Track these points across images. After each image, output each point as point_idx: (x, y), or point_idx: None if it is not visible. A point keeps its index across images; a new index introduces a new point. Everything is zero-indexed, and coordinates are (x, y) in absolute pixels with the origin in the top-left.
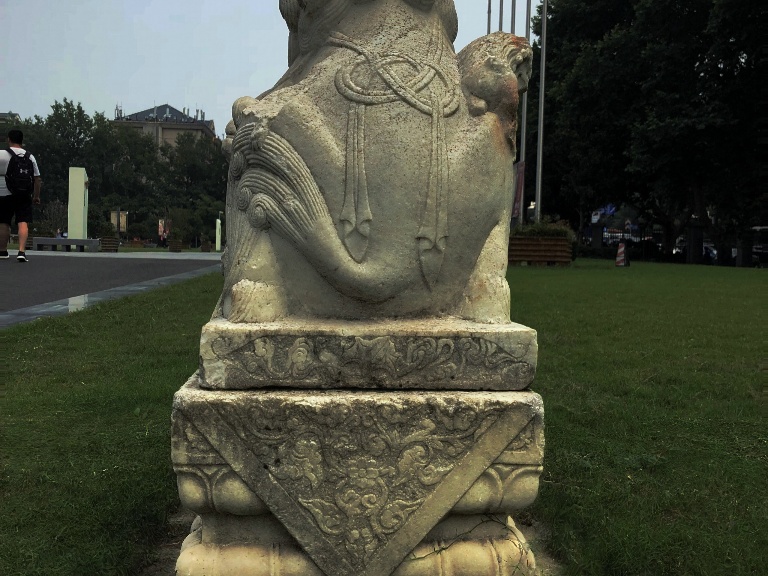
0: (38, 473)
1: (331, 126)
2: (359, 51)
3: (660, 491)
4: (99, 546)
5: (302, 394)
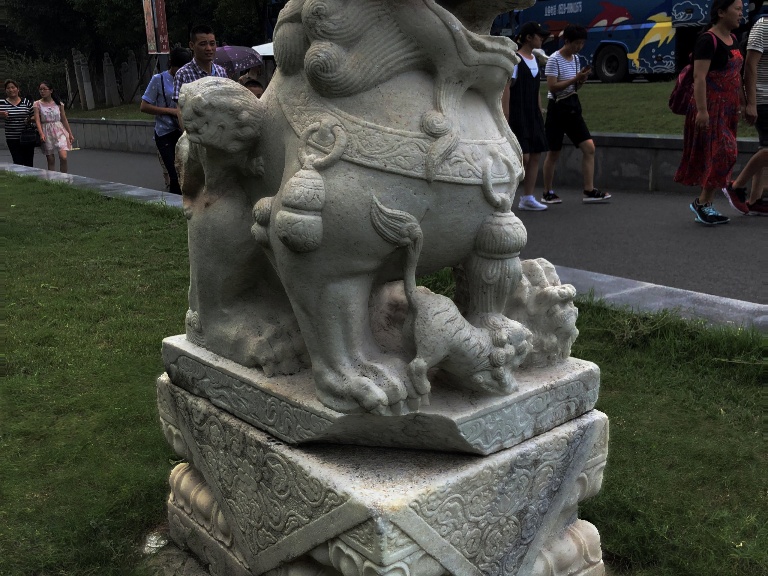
0: (759, 511)
1: None
2: None
3: None
4: None
5: None
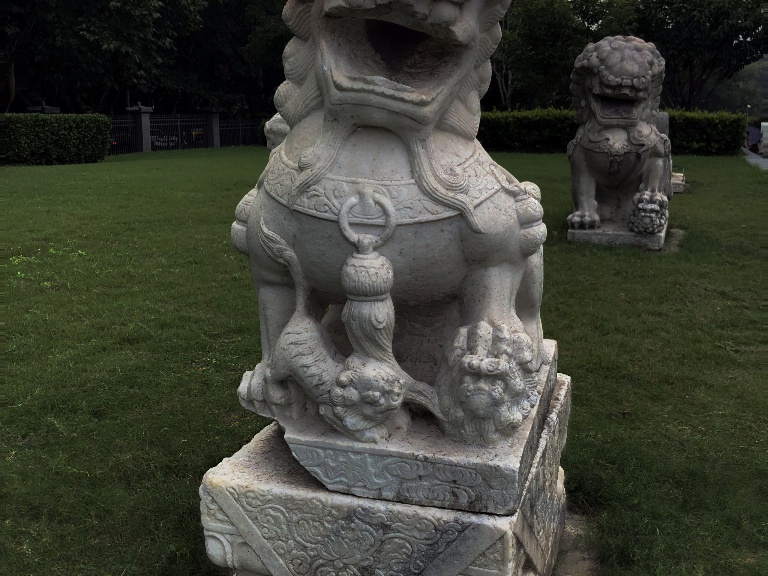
0: None
1: None
2: None
3: (49, 567)
4: None
5: None
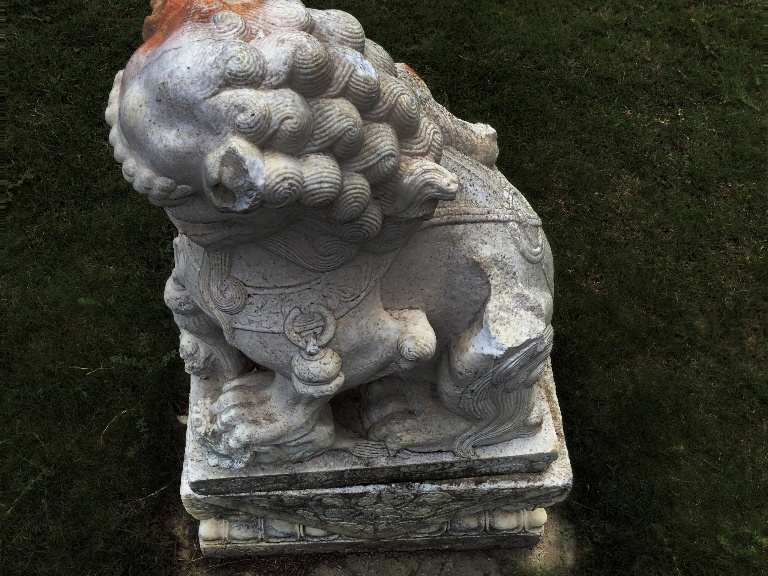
0: None
1: (542, 288)
2: (503, 221)
3: None
4: None
5: (550, 406)
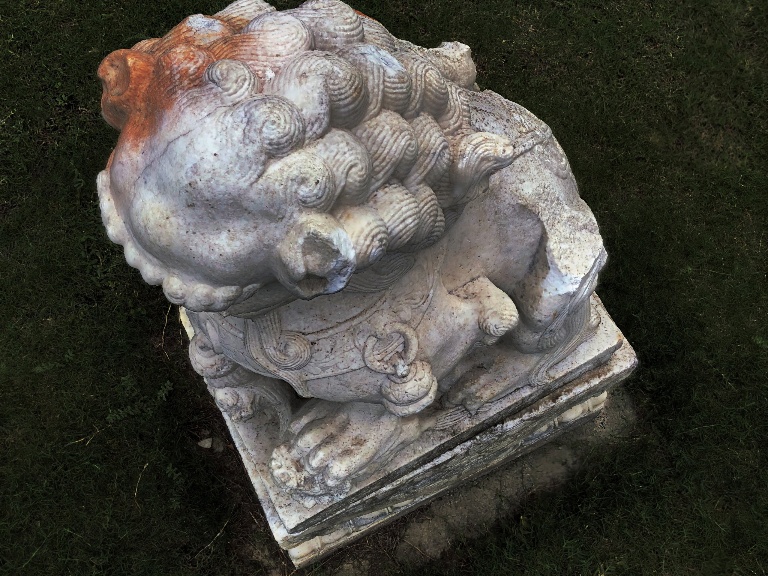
0: None
1: None
2: None
3: None
4: (496, 569)
5: None
